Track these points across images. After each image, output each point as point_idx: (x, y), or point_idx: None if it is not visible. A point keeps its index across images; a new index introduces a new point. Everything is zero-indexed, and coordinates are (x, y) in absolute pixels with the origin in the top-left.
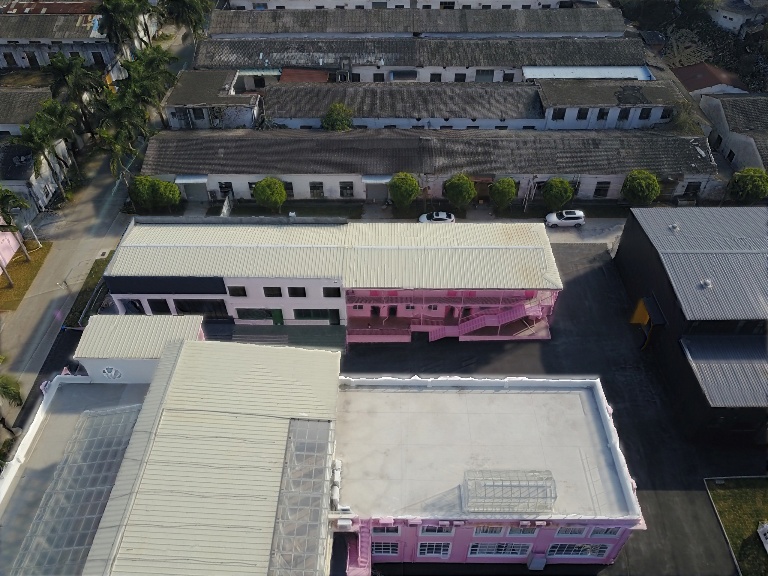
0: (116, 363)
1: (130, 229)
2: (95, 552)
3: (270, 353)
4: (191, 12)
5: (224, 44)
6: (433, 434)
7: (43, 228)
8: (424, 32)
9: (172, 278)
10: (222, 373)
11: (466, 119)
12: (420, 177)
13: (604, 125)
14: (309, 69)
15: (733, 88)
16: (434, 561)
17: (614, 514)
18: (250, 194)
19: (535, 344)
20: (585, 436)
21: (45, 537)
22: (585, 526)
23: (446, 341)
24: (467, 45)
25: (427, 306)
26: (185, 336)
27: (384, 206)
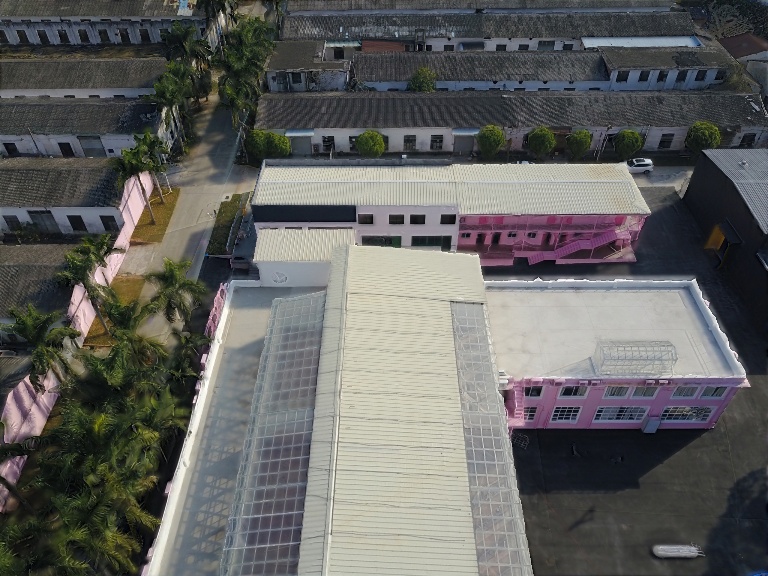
0: (288, 266)
1: (263, 170)
2: (321, 389)
3: (421, 255)
4: None
5: (306, 19)
6: (560, 321)
7: (168, 177)
8: (486, 8)
9: (311, 206)
10: (386, 268)
11: (538, 81)
12: (504, 130)
13: (663, 86)
14: (386, 41)
15: None
16: (562, 427)
17: (722, 376)
18: (349, 147)
19: (623, 266)
20: (688, 322)
21: (272, 383)
22: (699, 385)
23: (544, 264)
24: (529, 19)
25: (527, 234)
26: (344, 244)
27: (470, 158)
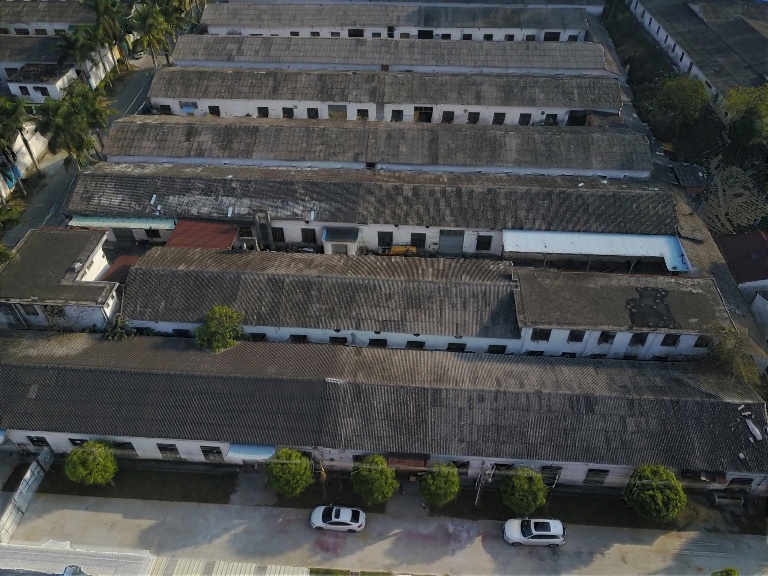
0: None
1: None
2: None
3: None
4: (68, 137)
5: (109, 179)
6: None
7: None
8: (380, 162)
9: None
10: None
11: (405, 334)
12: (317, 449)
13: (609, 349)
14: (213, 221)
15: None
16: None
17: None
18: None
19: None
20: None
21: None
22: None
23: None
24: (430, 193)
25: None
26: None
27: None
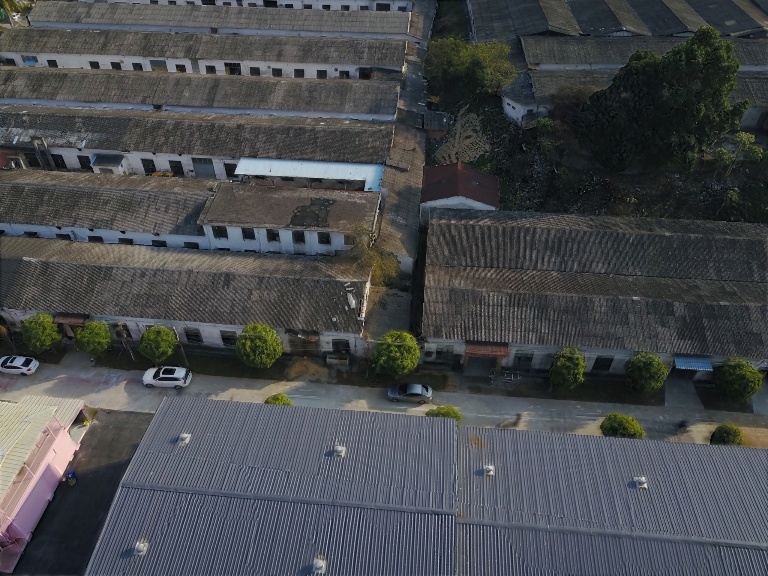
0: None
1: None
2: None
3: None
4: None
5: None
6: None
7: None
8: (164, 105)
9: None
10: None
11: (112, 231)
12: (4, 311)
13: (280, 247)
14: (1, 148)
15: (474, 201)
16: None
17: None
18: None
19: None
20: None
21: None
22: None
23: None
24: (188, 127)
25: None
26: None
27: None
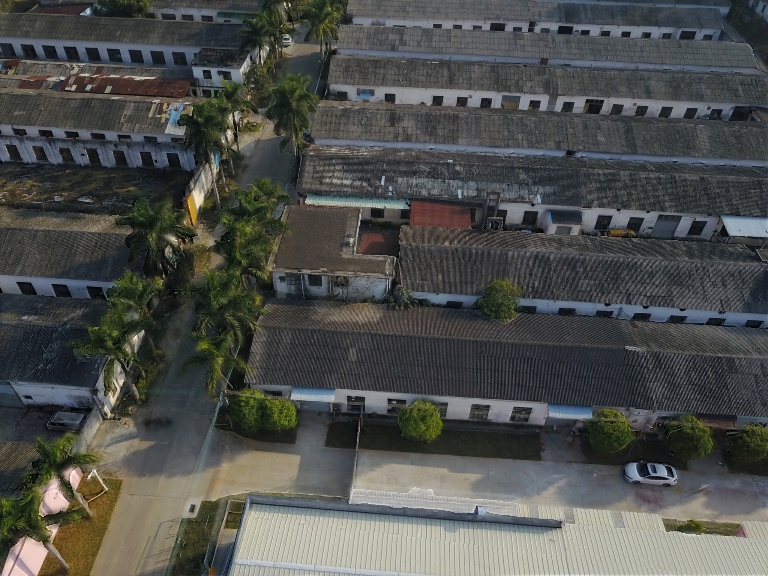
0: None
1: (244, 520)
2: None
3: None
4: (297, 119)
5: (336, 161)
6: None
7: (108, 451)
8: (581, 151)
9: None
10: None
11: (673, 308)
12: (629, 411)
13: None
14: (444, 203)
15: None
16: None
17: None
18: (387, 410)
19: None
20: None
21: None
22: None
23: None
24: (646, 180)
25: None
26: None
27: (569, 438)
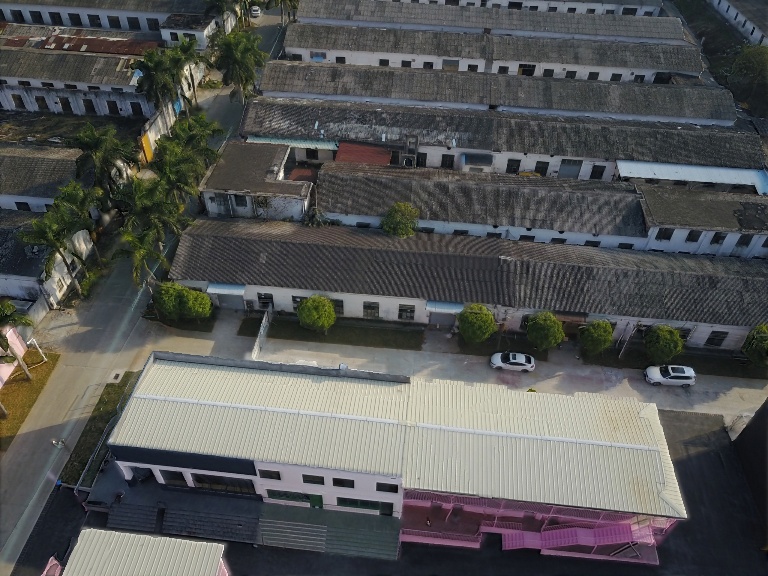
0: None
1: (147, 369)
2: None
3: None
4: (242, 70)
5: (276, 108)
6: None
7: (51, 333)
8: (502, 105)
9: (191, 455)
10: None
11: (552, 231)
12: (496, 308)
13: (718, 249)
14: (370, 145)
15: None
16: None
17: None
18: (293, 307)
19: (638, 570)
20: None
21: None
22: None
23: (524, 553)
24: (553, 128)
25: None
26: None
27: (449, 334)
